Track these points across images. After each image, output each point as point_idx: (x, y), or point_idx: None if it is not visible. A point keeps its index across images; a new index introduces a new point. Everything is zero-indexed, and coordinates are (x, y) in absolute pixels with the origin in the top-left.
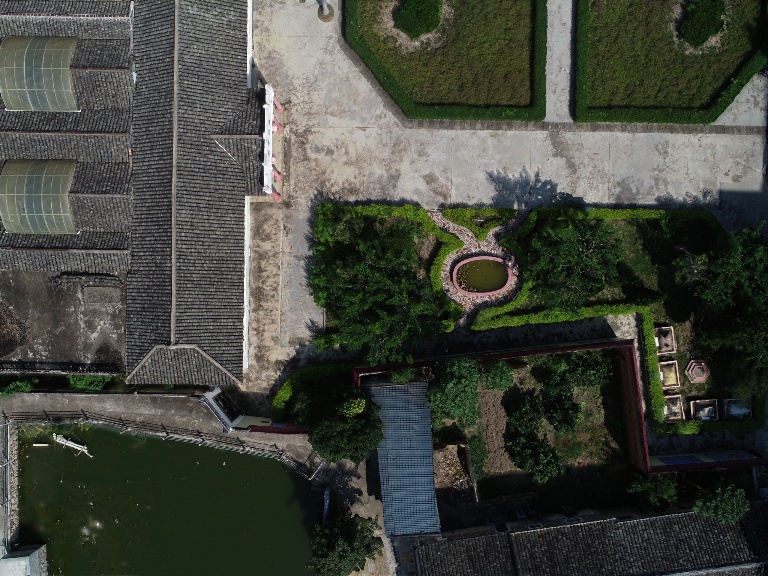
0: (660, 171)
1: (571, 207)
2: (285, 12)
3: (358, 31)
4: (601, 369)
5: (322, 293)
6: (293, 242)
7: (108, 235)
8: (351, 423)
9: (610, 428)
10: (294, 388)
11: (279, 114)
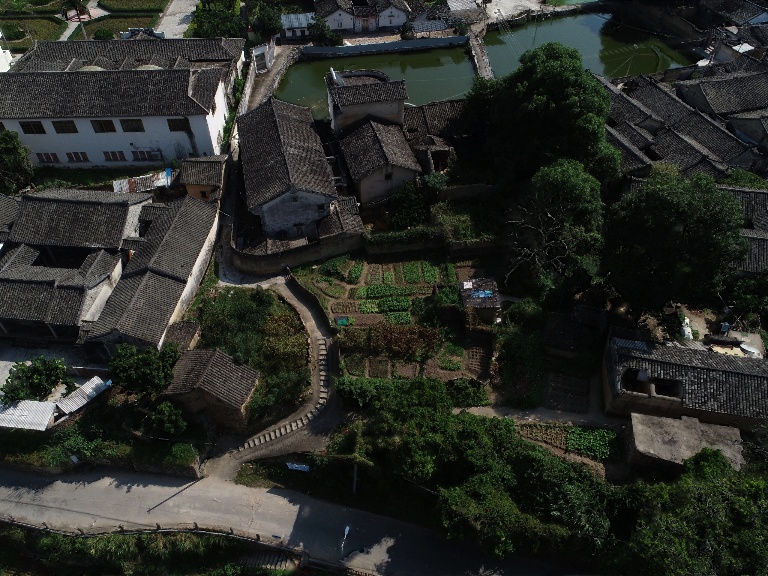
0: (188, 0)
1: None
2: None
3: None
4: None
5: None
6: None
7: None
8: None
9: (284, 6)
10: None
11: None
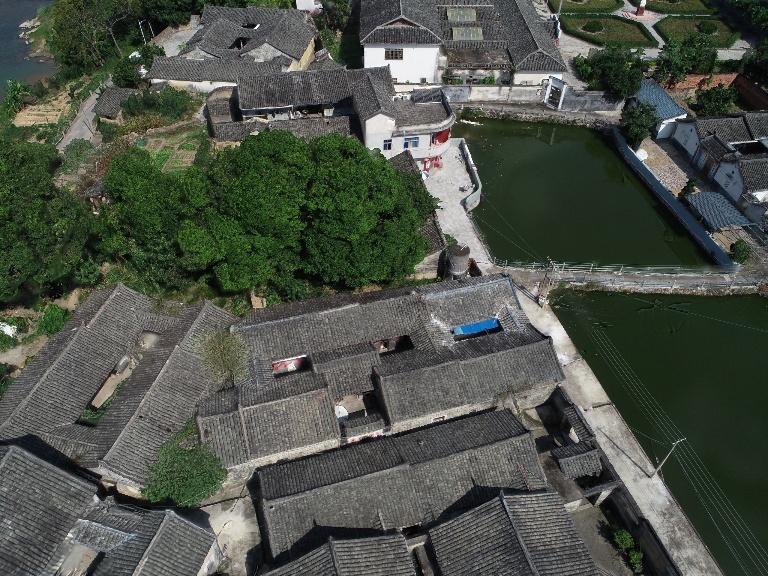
0: None
1: None
2: None
3: None
4: None
5: None
6: None
7: None
8: None
9: None
10: None
11: None
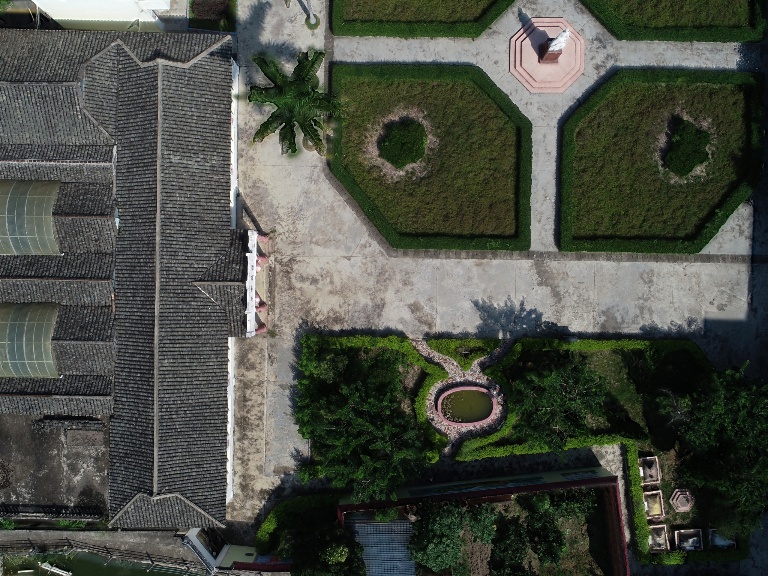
0: (645, 300)
1: (556, 336)
2: (270, 141)
3: (343, 161)
4: (585, 502)
5: (306, 429)
6: (278, 371)
7: (91, 379)
8: (334, 570)
9: (595, 556)
10: (278, 520)
11: (264, 244)
